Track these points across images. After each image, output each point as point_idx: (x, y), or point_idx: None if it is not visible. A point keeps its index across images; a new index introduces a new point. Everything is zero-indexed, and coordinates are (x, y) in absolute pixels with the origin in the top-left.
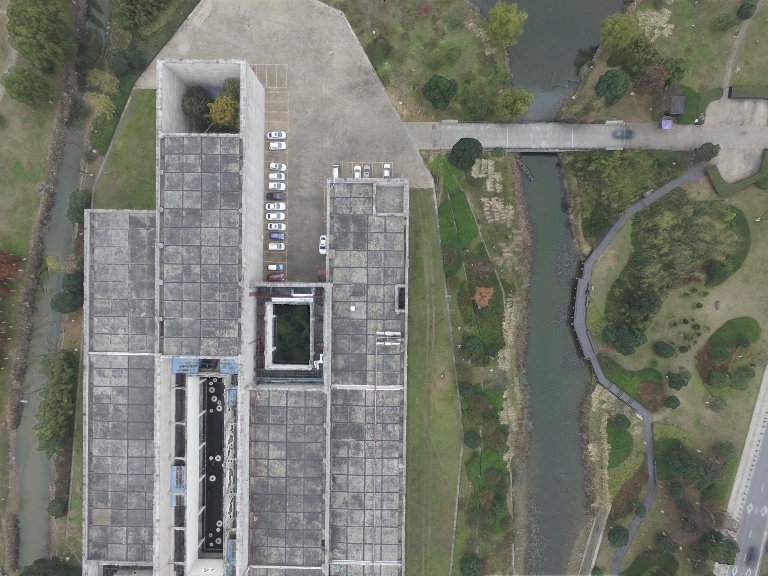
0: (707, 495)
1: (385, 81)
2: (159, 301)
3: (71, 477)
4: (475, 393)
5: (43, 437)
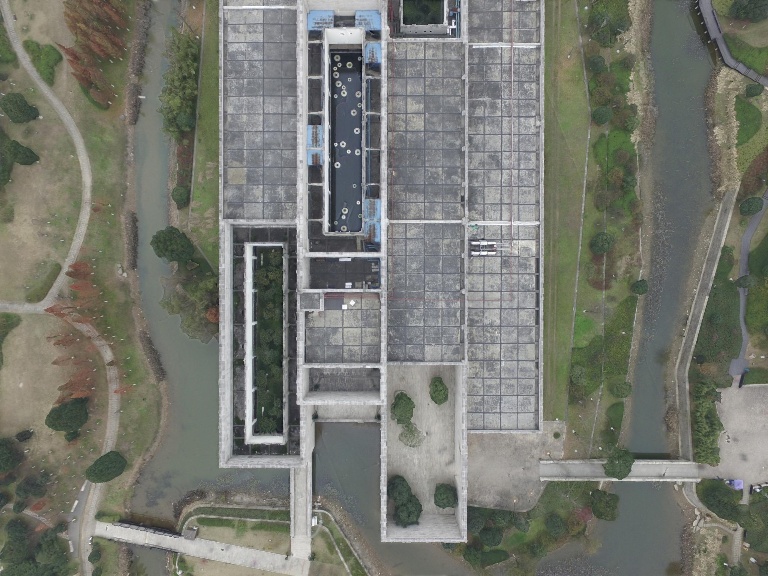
0: None
1: None
2: None
3: (193, 167)
4: (603, 71)
5: (169, 113)
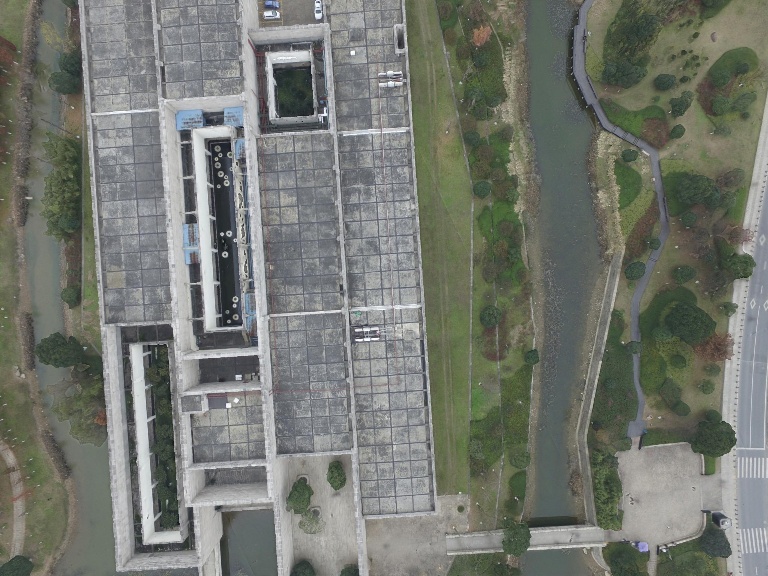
0: (719, 227)
1: None
2: (158, 47)
3: (82, 265)
4: (481, 144)
5: (51, 218)
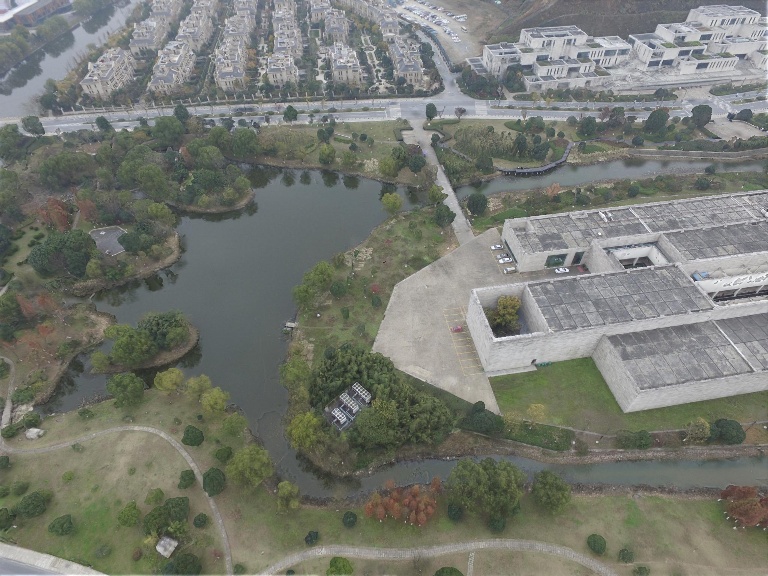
0: None
1: (436, 258)
2: None
3: None
4: None
5: None
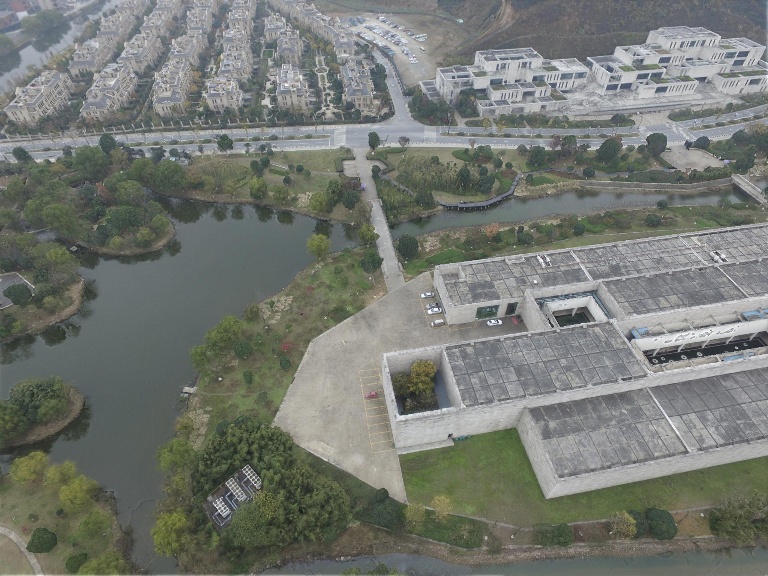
0: None
1: (360, 308)
2: None
3: None
4: None
5: None
